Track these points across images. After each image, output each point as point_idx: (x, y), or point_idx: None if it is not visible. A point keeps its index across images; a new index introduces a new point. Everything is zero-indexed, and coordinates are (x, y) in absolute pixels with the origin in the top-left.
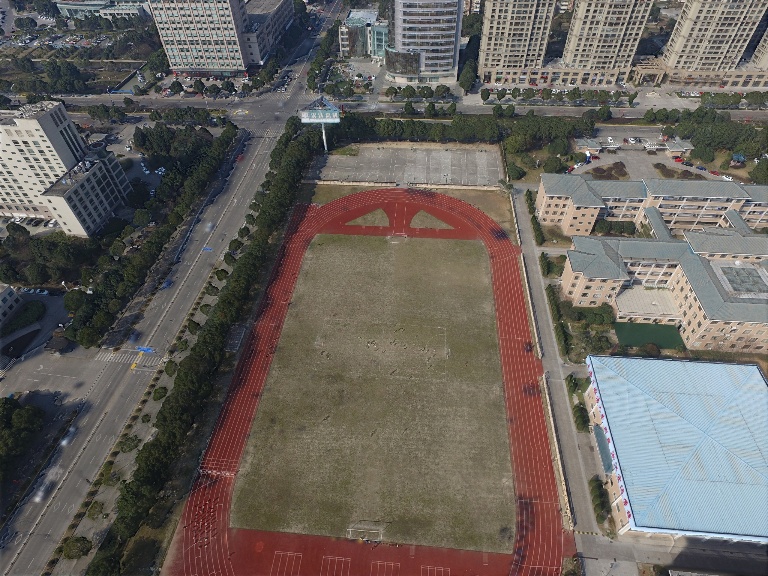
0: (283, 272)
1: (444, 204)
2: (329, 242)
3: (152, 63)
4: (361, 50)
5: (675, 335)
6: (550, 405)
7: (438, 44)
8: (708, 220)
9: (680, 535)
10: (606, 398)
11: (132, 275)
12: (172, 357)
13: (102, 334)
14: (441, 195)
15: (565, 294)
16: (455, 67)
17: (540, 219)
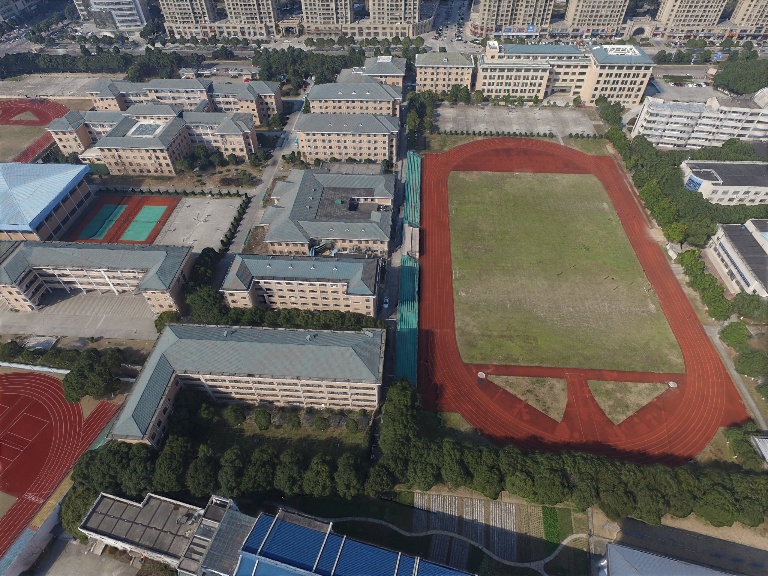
0: None
1: (49, 107)
2: None
3: None
4: None
5: None
6: None
7: (120, 4)
8: None
9: None
10: None
11: None
12: None
13: None
14: (53, 102)
15: (60, 148)
16: (144, 23)
17: None
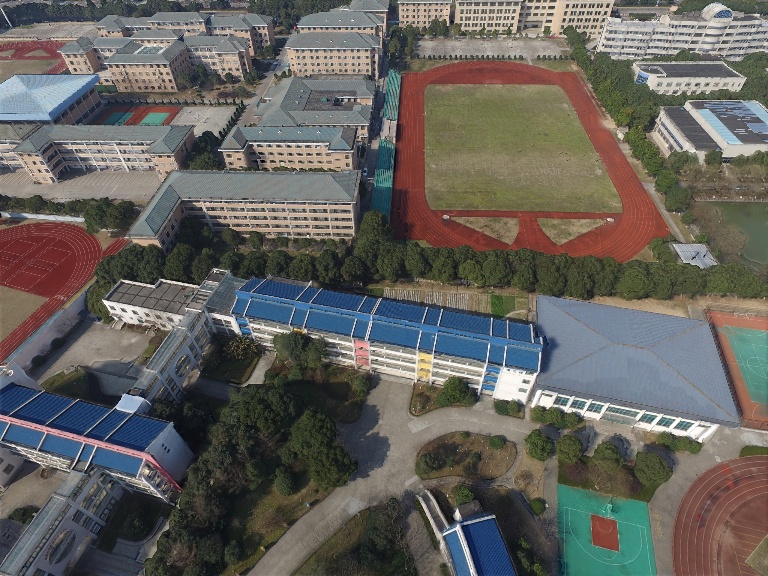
0: None
1: (59, 46)
2: None
3: None
4: None
5: None
6: None
7: None
8: None
9: None
10: None
11: None
12: None
13: None
14: (62, 43)
15: None
16: None
17: None
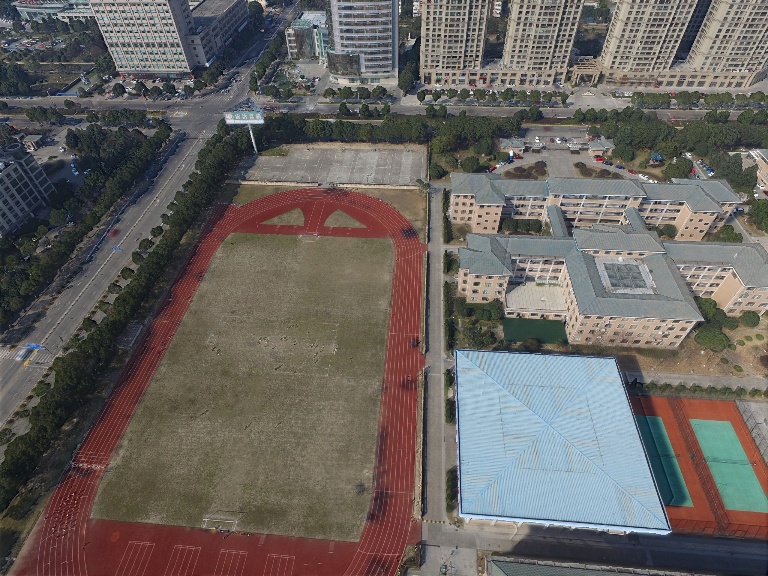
0: (191, 271)
1: (361, 203)
2: (241, 241)
3: (99, 65)
4: (309, 52)
5: (560, 330)
6: (423, 398)
7: (376, 46)
8: (610, 218)
9: (520, 523)
10: (462, 391)
11: (36, 274)
12: (66, 354)
13: (2, 332)
14: (360, 194)
15: (459, 291)
16: (395, 68)
17: (450, 218)
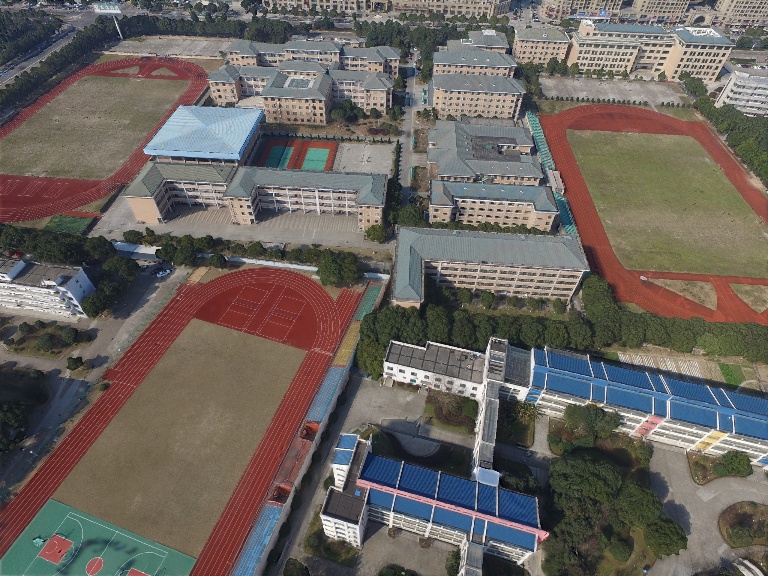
0: (54, 91)
1: (181, 65)
2: (92, 79)
3: None
4: None
5: None
6: None
7: None
8: None
9: None
10: (172, 117)
11: None
12: None
13: None
14: (183, 61)
15: (214, 99)
16: None
17: None
